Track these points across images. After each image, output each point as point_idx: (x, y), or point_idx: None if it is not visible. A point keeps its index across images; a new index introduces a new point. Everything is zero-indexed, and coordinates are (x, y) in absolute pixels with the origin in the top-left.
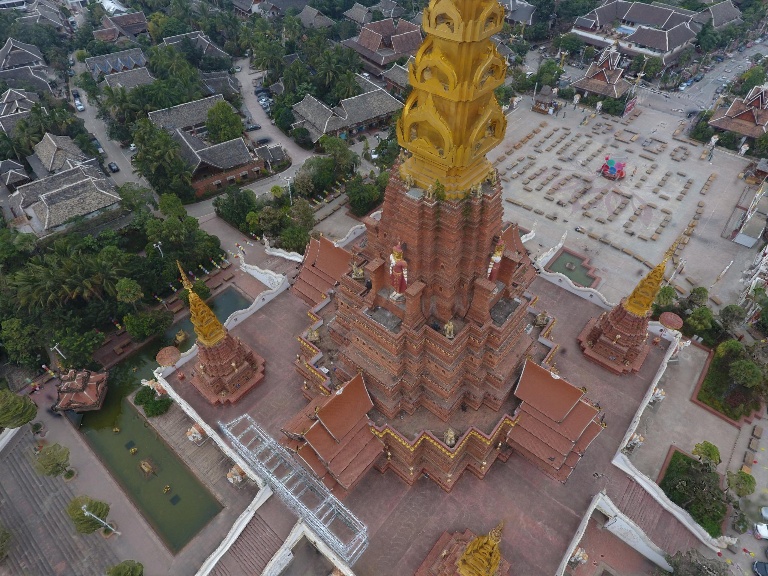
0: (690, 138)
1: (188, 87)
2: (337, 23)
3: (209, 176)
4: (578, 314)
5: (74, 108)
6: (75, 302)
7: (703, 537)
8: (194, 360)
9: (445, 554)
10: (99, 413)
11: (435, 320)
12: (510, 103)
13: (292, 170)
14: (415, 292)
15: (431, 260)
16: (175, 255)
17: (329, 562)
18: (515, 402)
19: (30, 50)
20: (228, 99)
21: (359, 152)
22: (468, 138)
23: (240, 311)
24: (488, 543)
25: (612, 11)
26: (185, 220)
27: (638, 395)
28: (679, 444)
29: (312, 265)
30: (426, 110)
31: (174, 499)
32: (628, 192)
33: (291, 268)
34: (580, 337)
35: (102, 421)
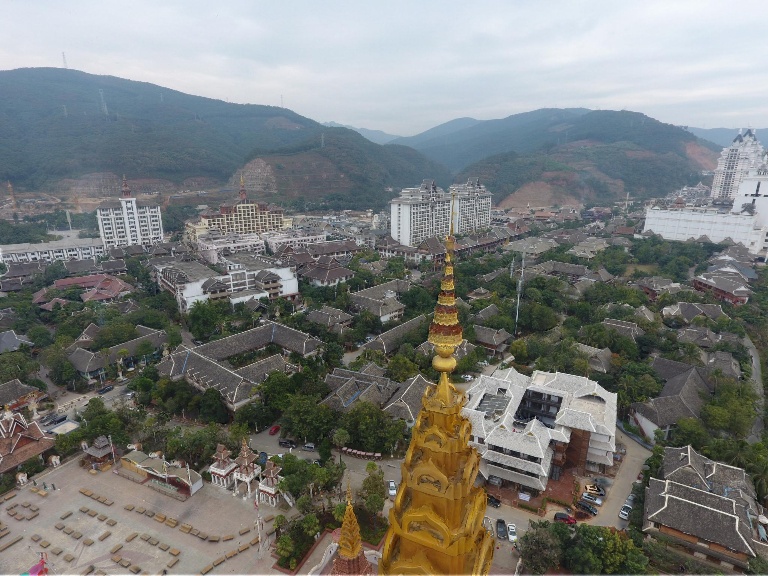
0: None
1: None
2: None
3: None
4: None
5: None
6: None
7: None
8: None
9: None
10: None
11: None
12: None
13: None
14: None
15: None
16: None
17: None
18: None
19: None
20: None
21: None
22: None
23: None
24: None
25: None
26: None
27: None
28: None
29: None
30: (483, 548)
31: None
32: (78, 571)
33: None
34: None
35: None
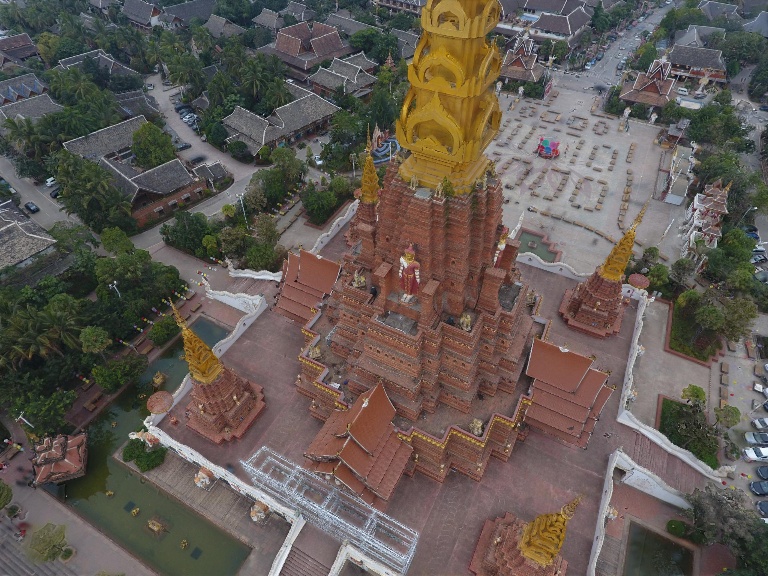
0: (606, 113)
1: (104, 111)
2: (248, 30)
3: (149, 203)
4: (553, 288)
5: None
6: (29, 363)
7: (705, 471)
8: (184, 401)
9: (499, 541)
10: (84, 479)
11: (447, 316)
12: None
13: (236, 186)
14: (432, 291)
15: (443, 257)
16: (134, 293)
17: None
18: (526, 381)
19: None
20: (149, 119)
21: None
22: (471, 133)
23: (223, 341)
24: (558, 520)
25: (513, 1)
26: (135, 254)
27: (623, 354)
28: (665, 392)
29: (295, 281)
30: (432, 109)
31: (195, 553)
32: (565, 168)
33: (264, 287)
34: (561, 310)
35: (90, 487)
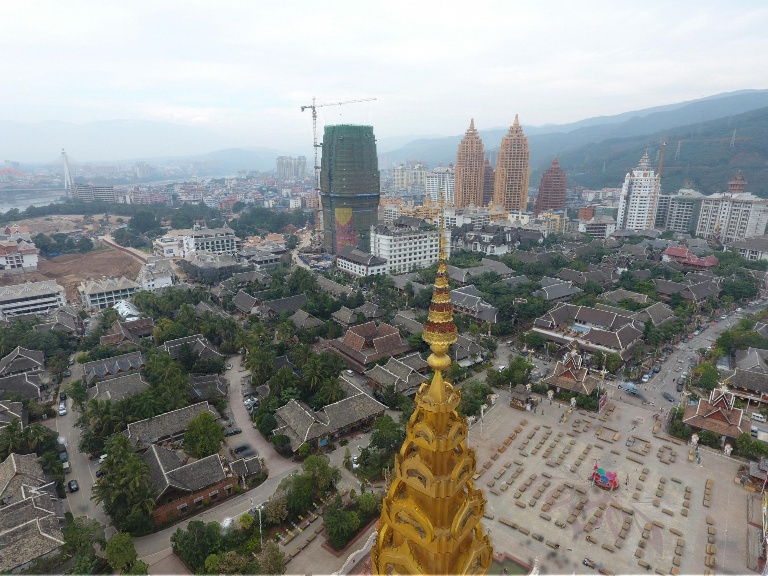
0: (670, 436)
1: (175, 396)
2: (325, 323)
3: (174, 500)
4: None
5: (56, 412)
6: None
7: None
8: None
9: None
10: None
11: None
12: (488, 400)
13: (267, 484)
14: None
15: None
16: None
17: None
18: None
19: (34, 357)
20: (213, 402)
21: (340, 459)
22: None
23: None
24: None
25: (564, 313)
26: (132, 569)
27: None
28: None
29: None
30: (402, 554)
31: None
32: (628, 506)
33: None
34: None
35: None
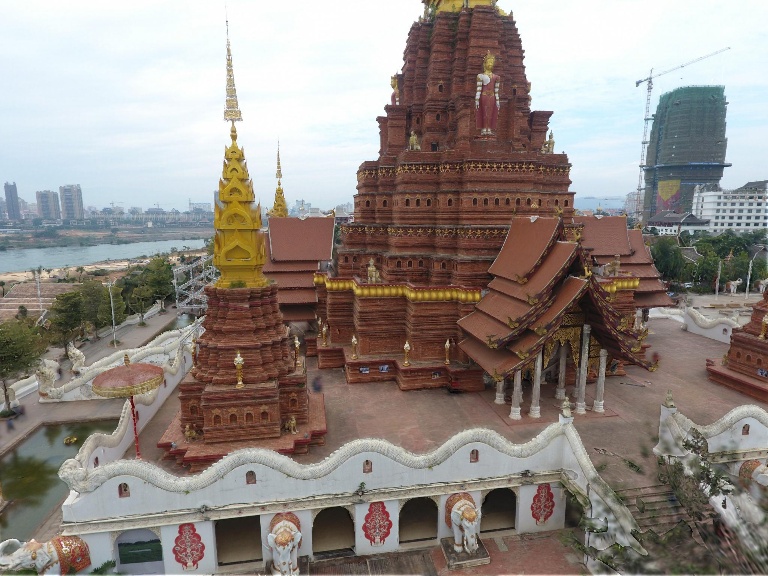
0: None
1: None
2: None
3: None
4: None
5: None
6: None
7: None
8: None
9: None
10: None
11: None
12: None
13: None
14: (391, 105)
15: (417, 82)
16: None
17: None
18: None
19: None
20: None
21: None
22: None
23: None
24: None
25: None
26: None
27: None
28: None
29: None
30: None
31: None
32: None
33: None
34: (713, 358)
35: None
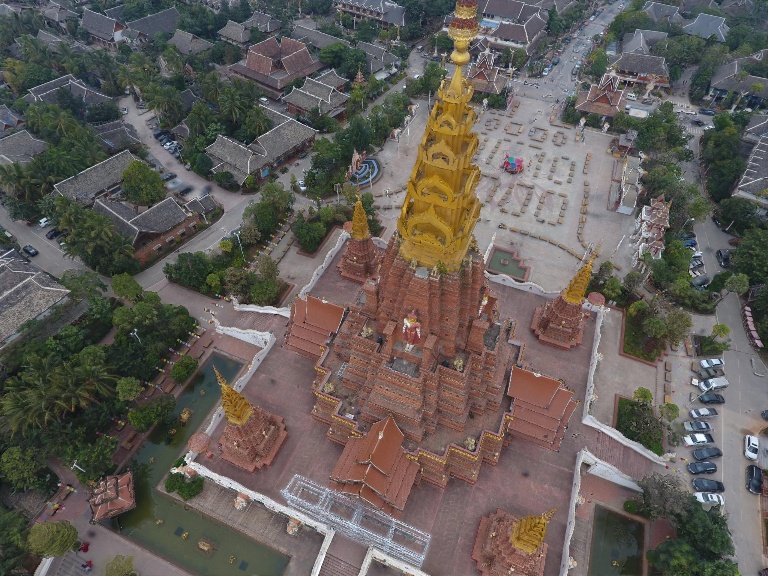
0: (563, 122)
1: (89, 149)
2: (215, 45)
3: (148, 243)
4: (525, 306)
5: None
6: None
7: (653, 458)
8: (214, 436)
9: (494, 535)
10: (134, 511)
11: (442, 357)
12: (409, 111)
13: (227, 217)
14: (432, 345)
15: (439, 317)
16: (152, 337)
17: (396, 571)
18: (507, 399)
19: None
20: (132, 151)
21: (286, 185)
22: (459, 226)
23: (242, 378)
24: (540, 522)
25: None
26: (146, 297)
27: (586, 363)
28: (620, 392)
29: (303, 322)
30: (428, 216)
31: (242, 565)
32: (530, 183)
33: (270, 322)
34: (533, 326)
35: (140, 518)
